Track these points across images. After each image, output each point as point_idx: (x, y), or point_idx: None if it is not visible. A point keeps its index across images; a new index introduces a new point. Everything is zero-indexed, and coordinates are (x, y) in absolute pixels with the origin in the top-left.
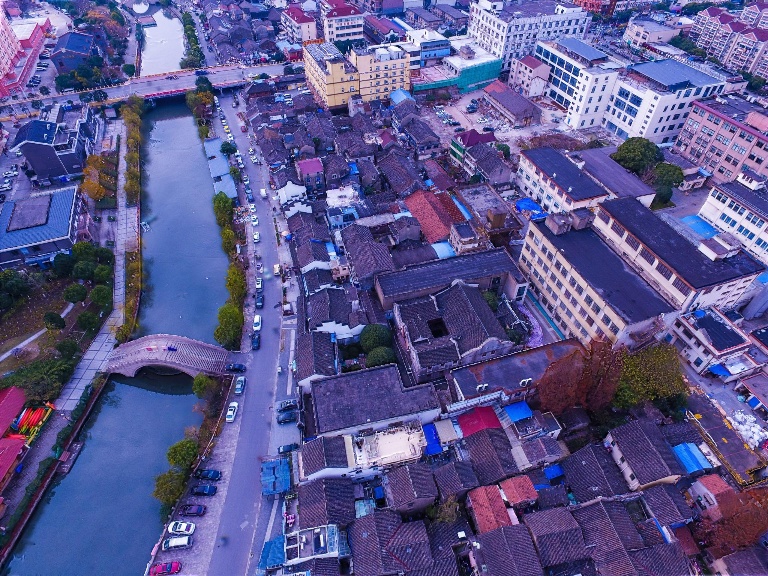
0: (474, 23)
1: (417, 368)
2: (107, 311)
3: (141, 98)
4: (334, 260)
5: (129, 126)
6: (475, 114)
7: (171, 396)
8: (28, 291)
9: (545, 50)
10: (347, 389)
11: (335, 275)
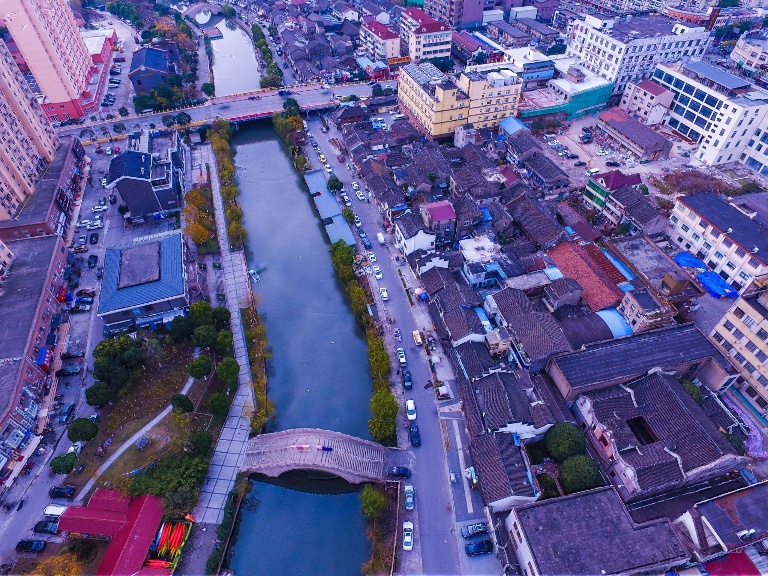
0: (576, 42)
1: (632, 488)
2: (233, 387)
3: (226, 121)
4: (492, 332)
5: (218, 154)
6: (591, 145)
7: (312, 495)
8: (144, 361)
9: (667, 74)
10: (563, 522)
11: (493, 350)
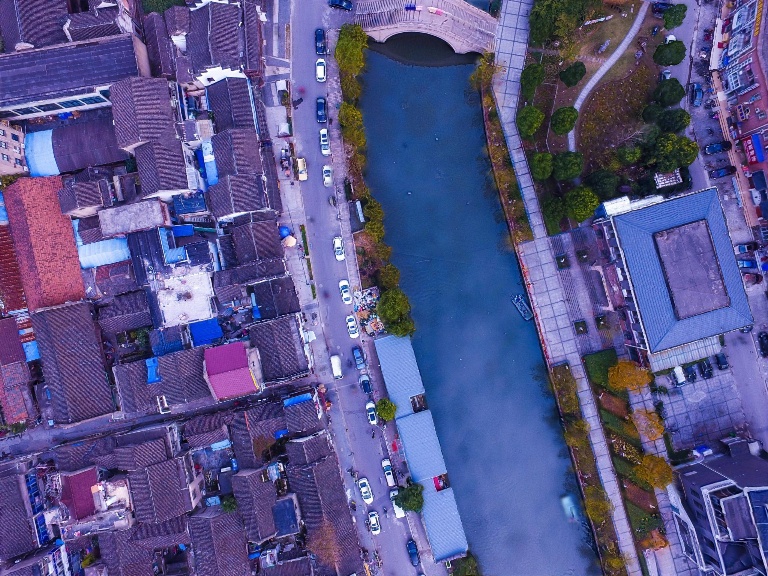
0: None
1: None
2: None
3: None
4: (205, 136)
5: None
6: None
7: None
8: None
9: None
10: None
11: None
